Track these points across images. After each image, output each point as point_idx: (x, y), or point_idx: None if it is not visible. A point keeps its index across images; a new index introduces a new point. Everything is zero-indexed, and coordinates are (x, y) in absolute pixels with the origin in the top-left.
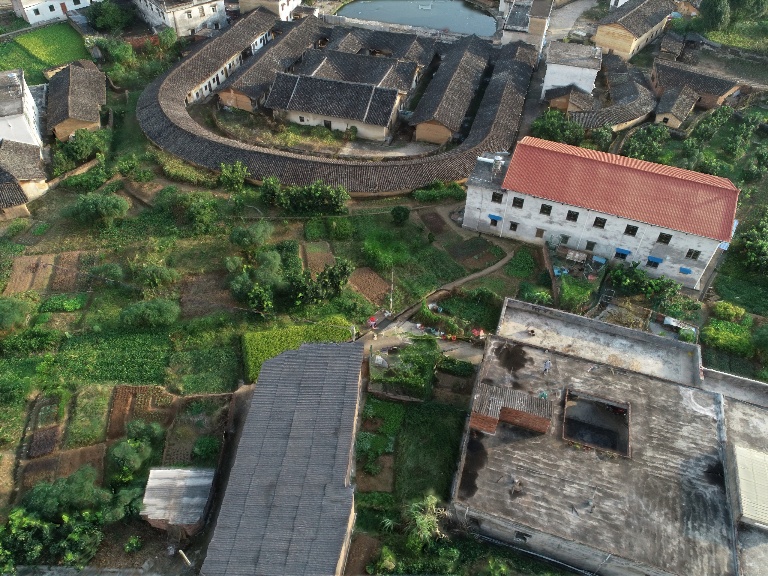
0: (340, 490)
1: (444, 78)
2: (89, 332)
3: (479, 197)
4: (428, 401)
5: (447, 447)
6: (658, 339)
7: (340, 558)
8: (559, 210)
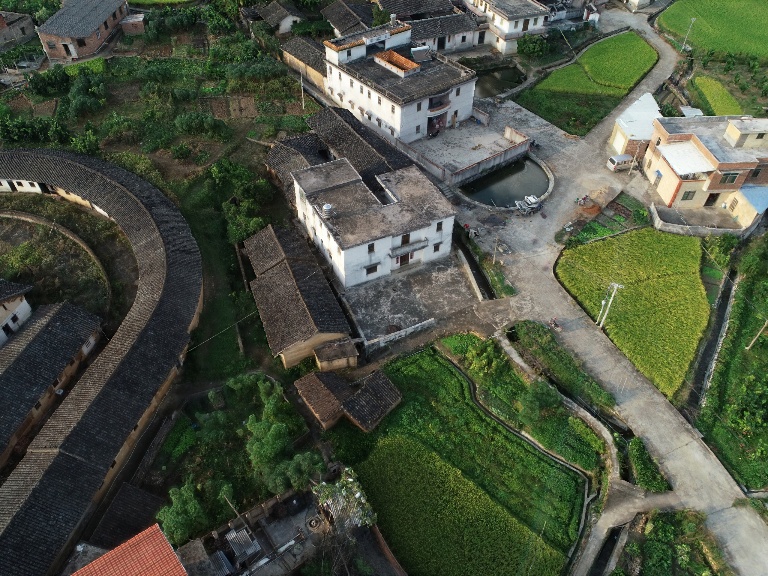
0: (68, 5)
1: None
2: (191, 77)
3: None
4: None
5: None
6: None
7: None
8: None
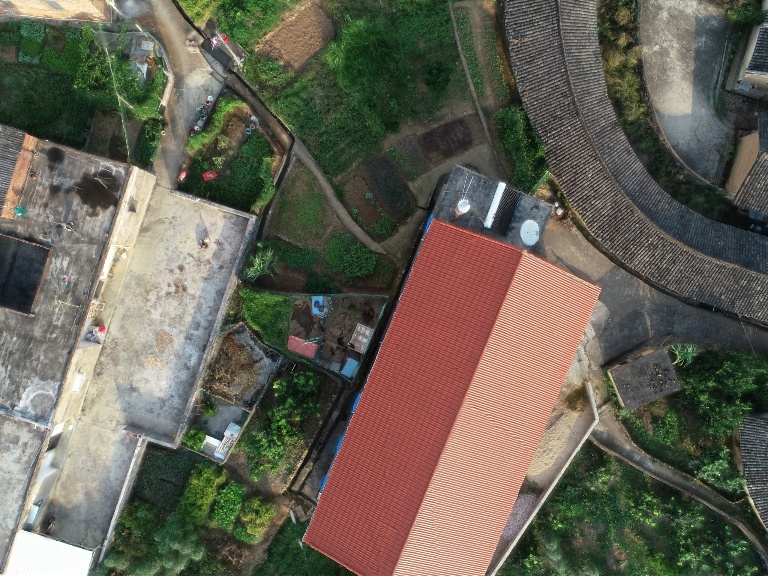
0: None
1: None
2: None
3: None
4: (88, 103)
5: (27, 120)
6: None
7: None
8: None
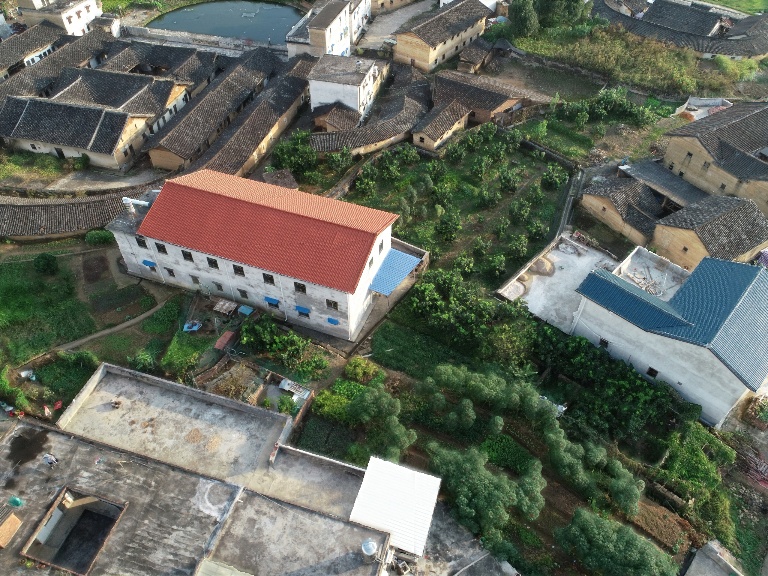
0: None
1: (200, 97)
2: None
3: (126, 242)
4: None
5: None
6: (251, 409)
7: None
8: (199, 257)
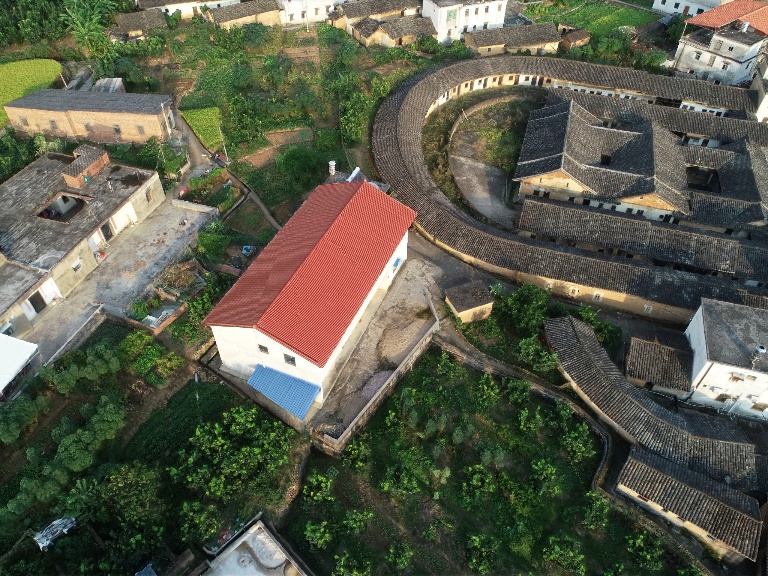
0: (67, 109)
1: None
2: None
3: None
4: None
5: None
6: None
7: (43, 120)
8: None
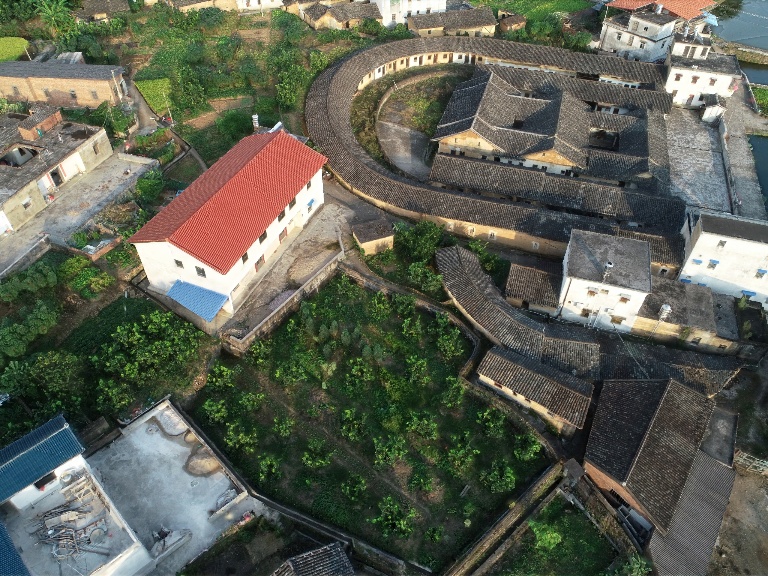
0: (27, 76)
1: None
2: None
3: None
4: None
5: None
6: None
7: (6, 86)
8: None
